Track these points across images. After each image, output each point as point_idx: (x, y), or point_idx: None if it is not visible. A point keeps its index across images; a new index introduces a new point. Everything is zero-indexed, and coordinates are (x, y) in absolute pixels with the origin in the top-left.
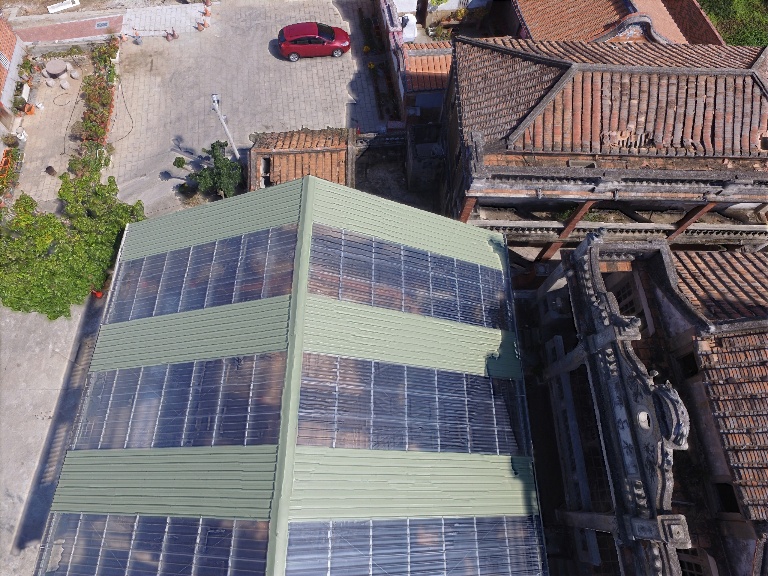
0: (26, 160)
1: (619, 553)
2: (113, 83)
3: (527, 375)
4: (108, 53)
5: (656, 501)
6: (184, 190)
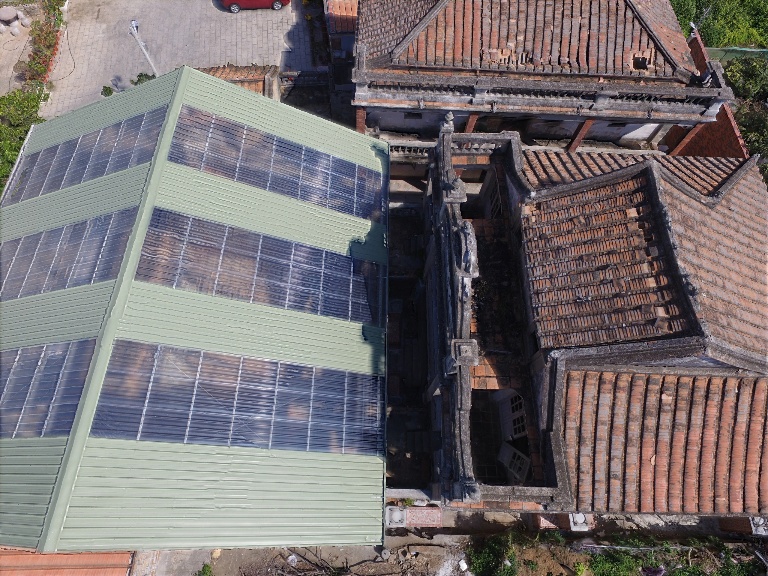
0: None
1: None
2: (59, 29)
3: (410, 278)
4: (57, 2)
5: (457, 332)
6: None
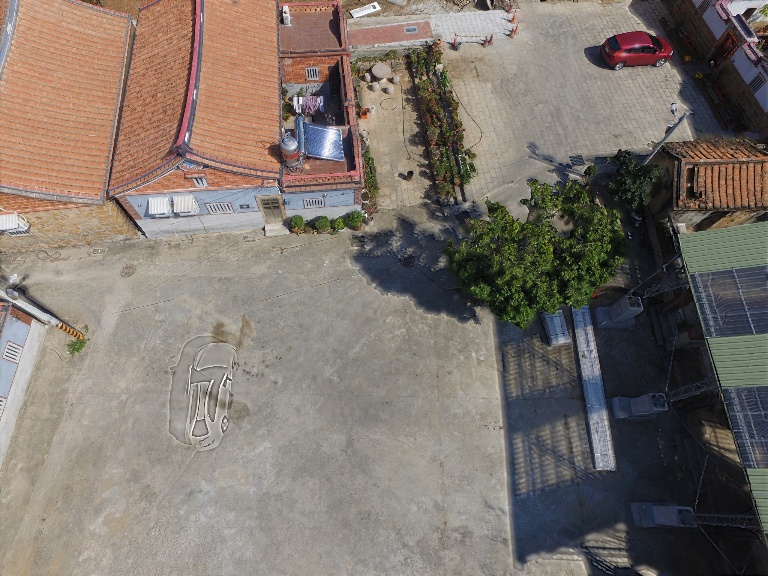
0: (375, 164)
1: None
2: (448, 89)
3: None
4: (434, 58)
5: None
6: None
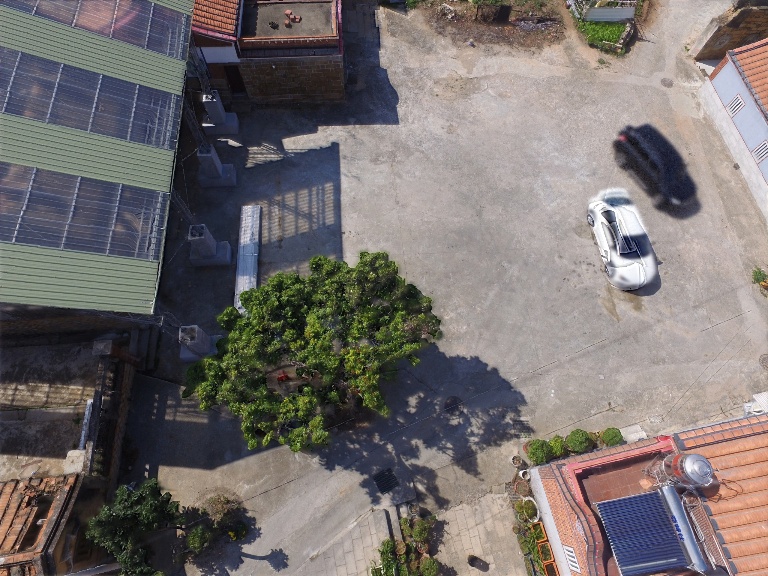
0: None
1: None
2: None
3: None
4: None
5: None
6: (237, 527)
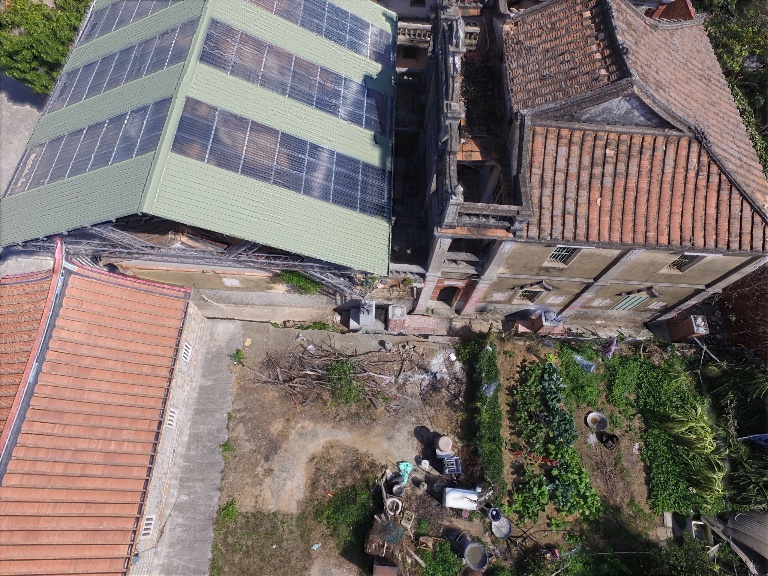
0: None
1: None
2: None
3: (413, 129)
4: None
5: None
6: None
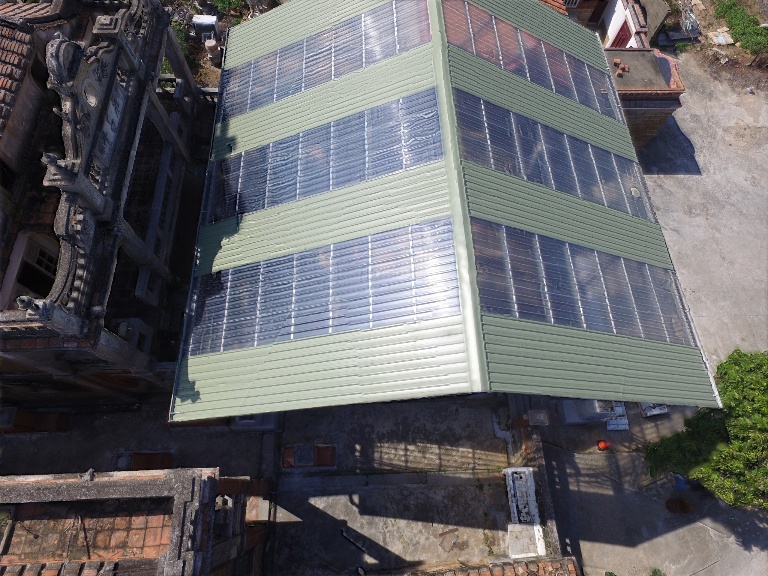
0: None
1: (156, 80)
2: None
3: None
4: None
5: None
6: None
